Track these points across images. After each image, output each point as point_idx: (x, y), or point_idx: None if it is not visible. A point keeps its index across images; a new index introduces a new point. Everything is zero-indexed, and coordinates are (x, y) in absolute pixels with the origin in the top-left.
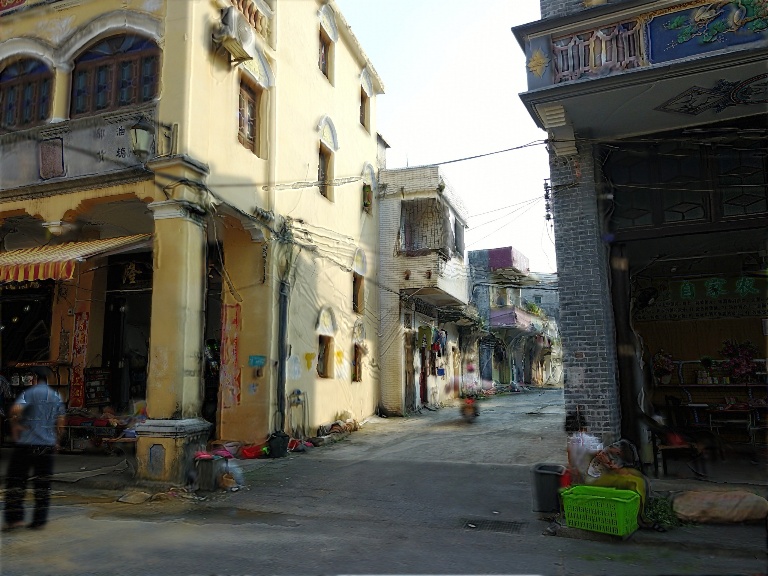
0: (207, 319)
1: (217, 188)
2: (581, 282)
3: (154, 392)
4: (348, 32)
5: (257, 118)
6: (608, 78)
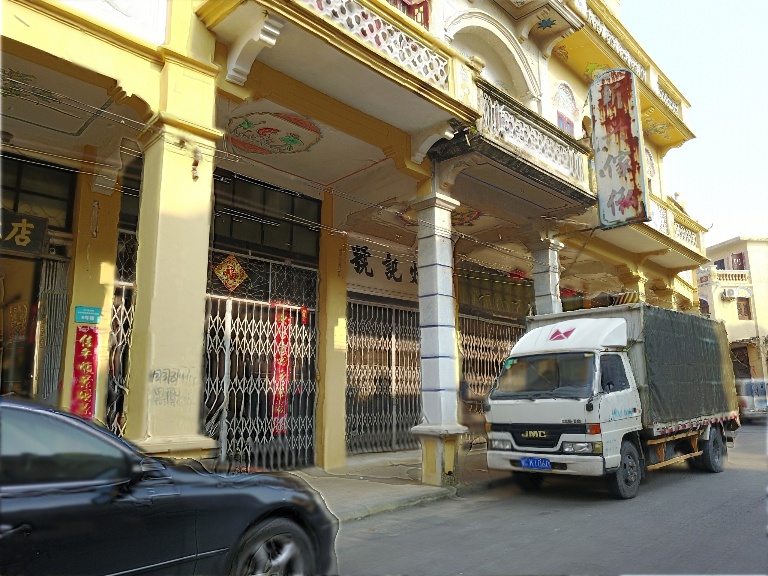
0: None
1: (731, 337)
2: None
3: None
4: None
5: (748, 307)
6: None
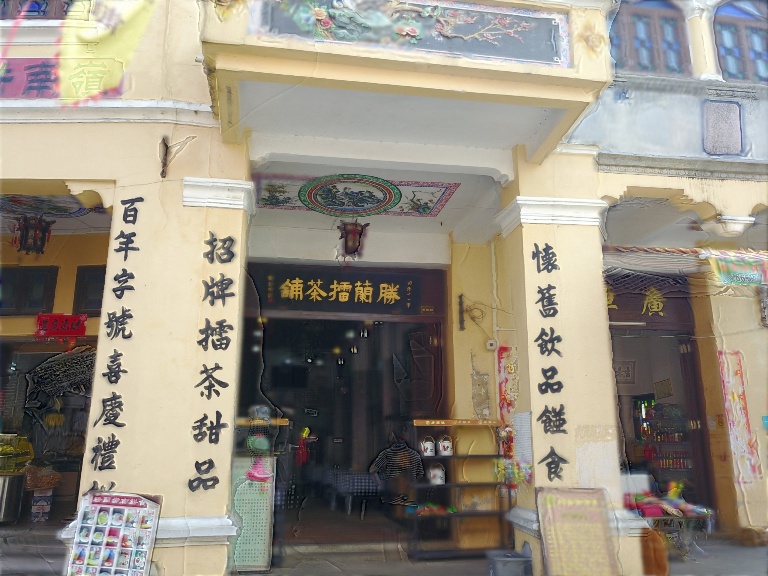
0: (648, 367)
1: None
2: None
3: None
4: None
5: None
6: None
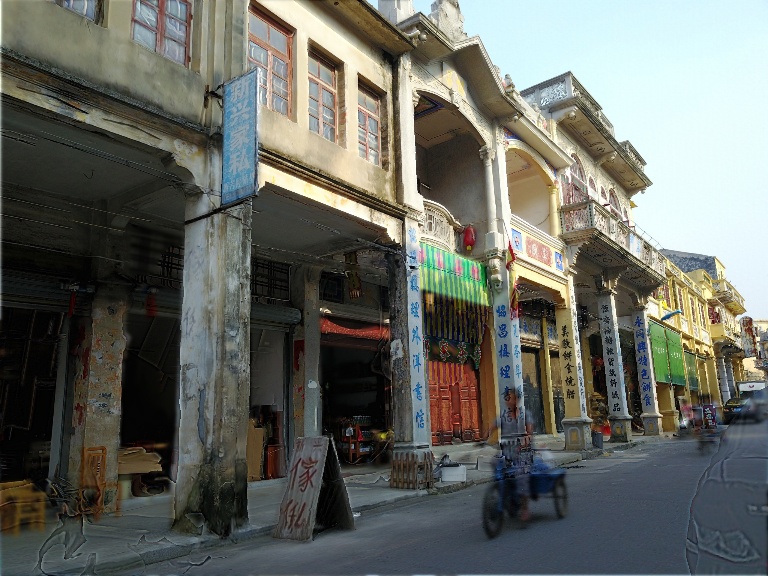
0: None
1: None
2: None
3: None
4: (762, 321)
5: None
6: (759, 367)
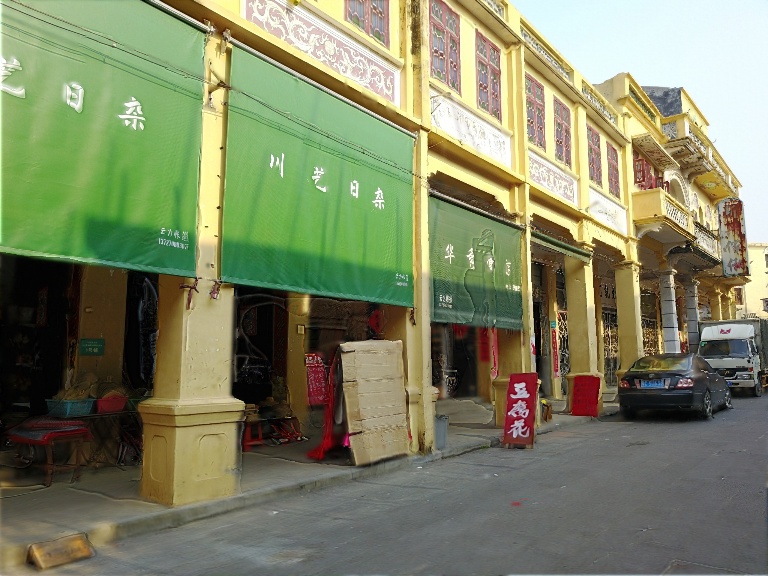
0: None
1: None
2: None
3: None
4: None
5: (741, 295)
6: None
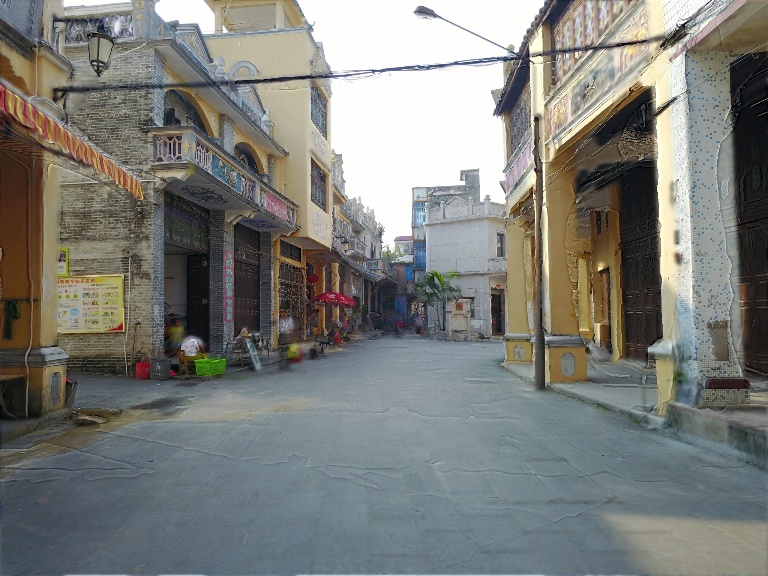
0: None
1: None
2: (159, 260)
3: (46, 318)
4: None
5: None
6: None
